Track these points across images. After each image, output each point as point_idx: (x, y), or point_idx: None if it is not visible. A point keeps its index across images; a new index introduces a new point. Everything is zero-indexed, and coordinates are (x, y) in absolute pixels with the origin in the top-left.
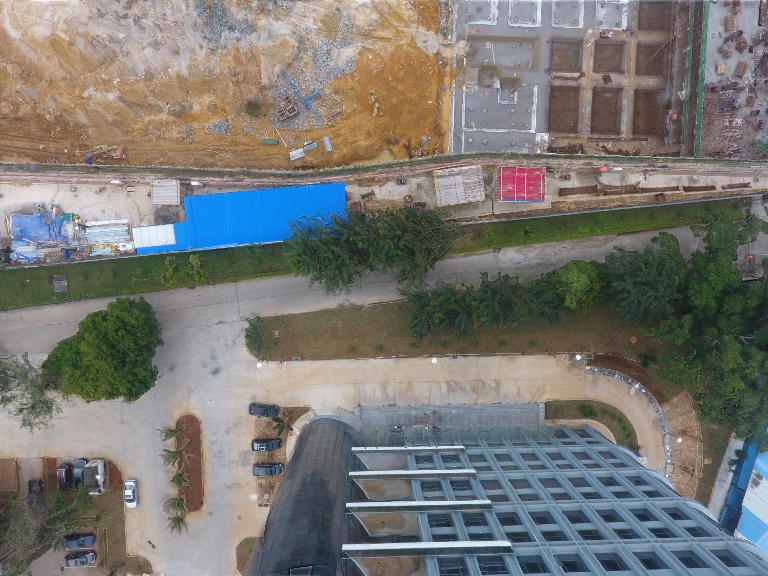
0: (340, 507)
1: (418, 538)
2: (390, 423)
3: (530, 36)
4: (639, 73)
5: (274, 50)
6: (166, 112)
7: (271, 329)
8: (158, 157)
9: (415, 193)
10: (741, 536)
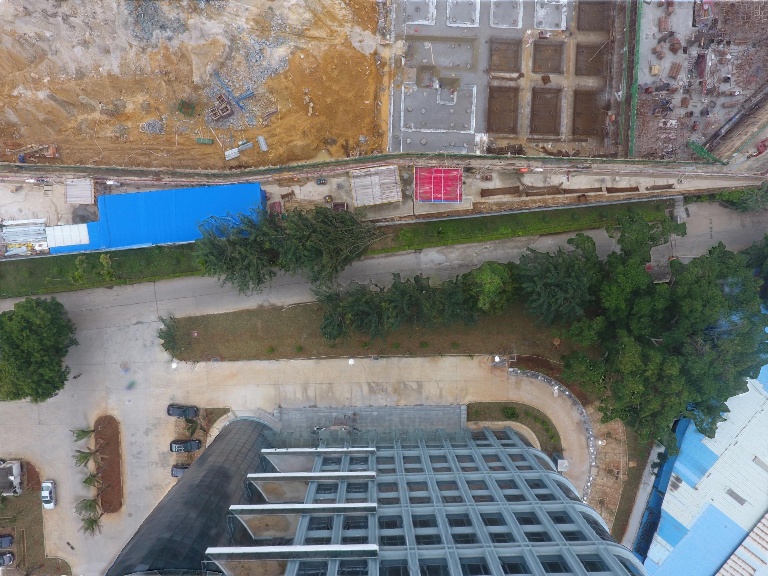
0: (222, 509)
1: (291, 541)
2: (310, 424)
3: (469, 36)
4: (579, 74)
5: (205, 49)
6: (99, 111)
7: (190, 329)
8: (92, 156)
9: (335, 193)
10: (660, 539)
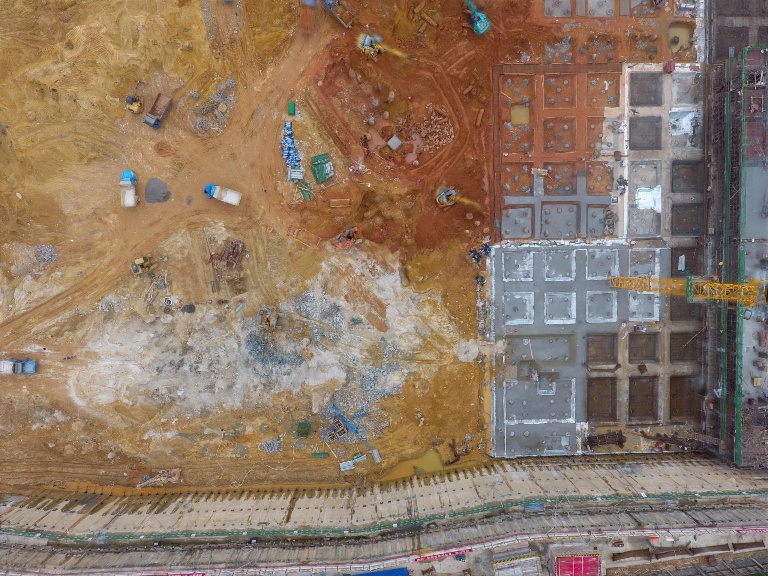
0: None
1: None
2: None
3: (566, 333)
4: (673, 359)
5: (324, 386)
6: (221, 436)
7: None
8: (213, 474)
9: (474, 566)
10: None
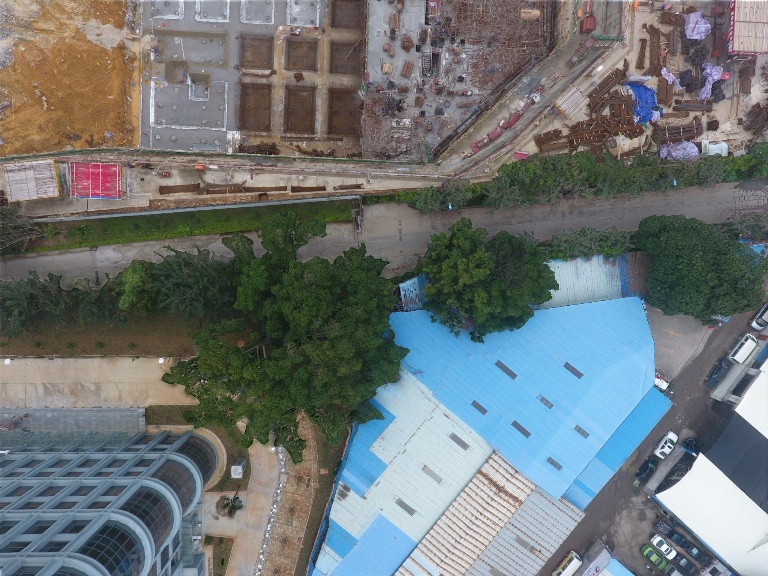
0: None
1: None
2: None
3: (218, 32)
4: (335, 72)
5: None
6: None
7: None
8: None
9: None
10: (329, 550)
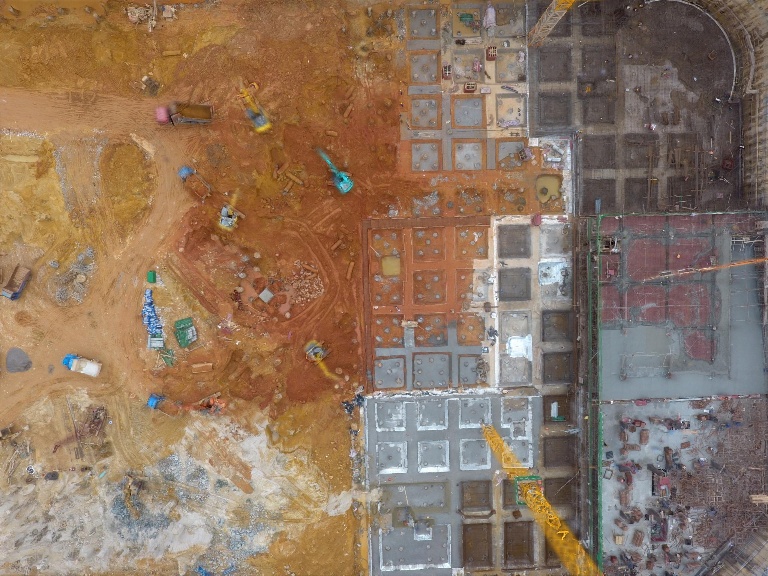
0: None
1: None
2: None
3: (440, 480)
4: None
5: (188, 551)
6: None
7: None
8: None
9: None
10: None
